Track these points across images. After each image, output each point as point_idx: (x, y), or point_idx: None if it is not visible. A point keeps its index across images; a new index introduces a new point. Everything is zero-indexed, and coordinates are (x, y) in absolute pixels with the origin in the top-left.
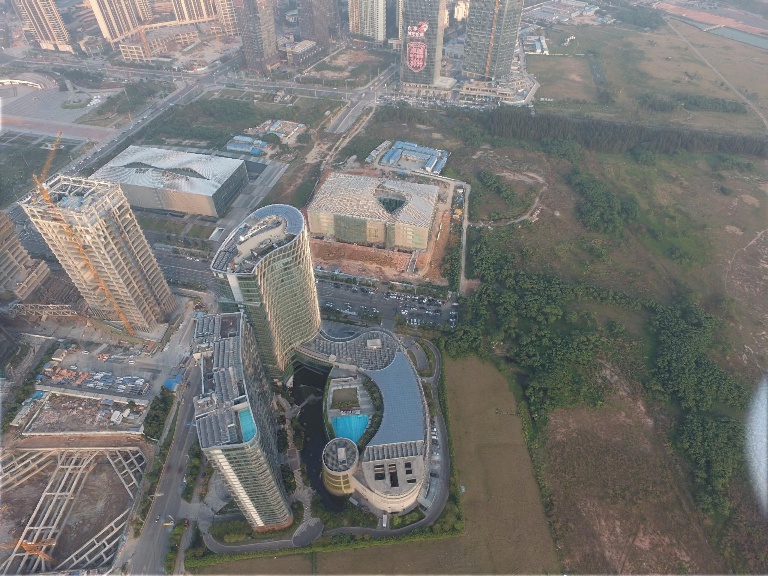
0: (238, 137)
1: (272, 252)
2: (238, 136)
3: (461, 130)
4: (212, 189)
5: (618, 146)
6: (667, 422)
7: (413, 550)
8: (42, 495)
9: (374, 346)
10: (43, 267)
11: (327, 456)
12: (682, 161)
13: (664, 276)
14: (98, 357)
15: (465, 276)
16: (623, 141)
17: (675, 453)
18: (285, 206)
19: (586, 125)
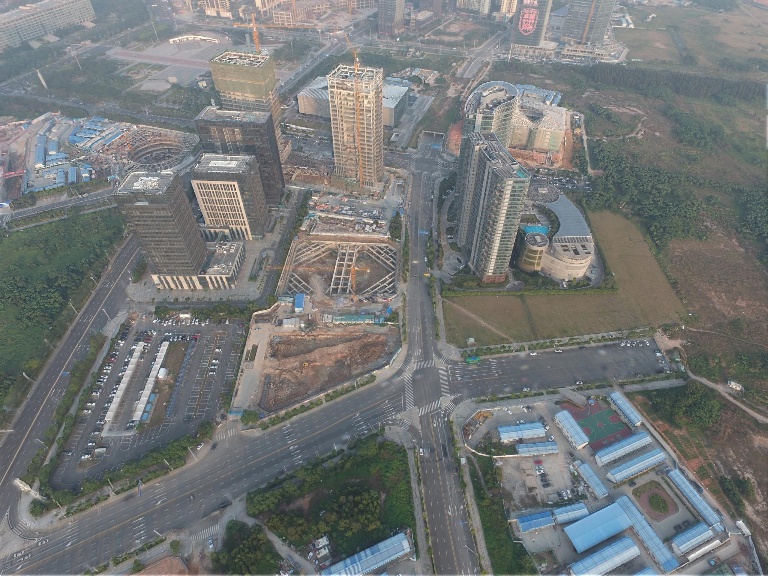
0: (390, 78)
1: (502, 104)
2: (389, 77)
3: (569, 78)
4: (393, 104)
5: (704, 91)
6: (755, 249)
7: (586, 298)
8: (336, 262)
9: (543, 191)
10: (290, 145)
11: (529, 240)
12: (759, 104)
13: (748, 173)
14: (342, 199)
15: (591, 168)
16: (708, 87)
17: (762, 265)
18: (502, 82)
19: (675, 77)
